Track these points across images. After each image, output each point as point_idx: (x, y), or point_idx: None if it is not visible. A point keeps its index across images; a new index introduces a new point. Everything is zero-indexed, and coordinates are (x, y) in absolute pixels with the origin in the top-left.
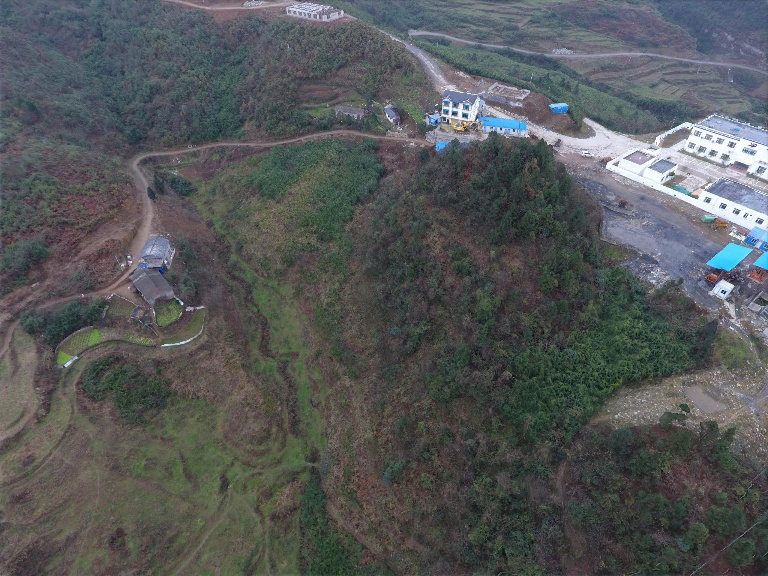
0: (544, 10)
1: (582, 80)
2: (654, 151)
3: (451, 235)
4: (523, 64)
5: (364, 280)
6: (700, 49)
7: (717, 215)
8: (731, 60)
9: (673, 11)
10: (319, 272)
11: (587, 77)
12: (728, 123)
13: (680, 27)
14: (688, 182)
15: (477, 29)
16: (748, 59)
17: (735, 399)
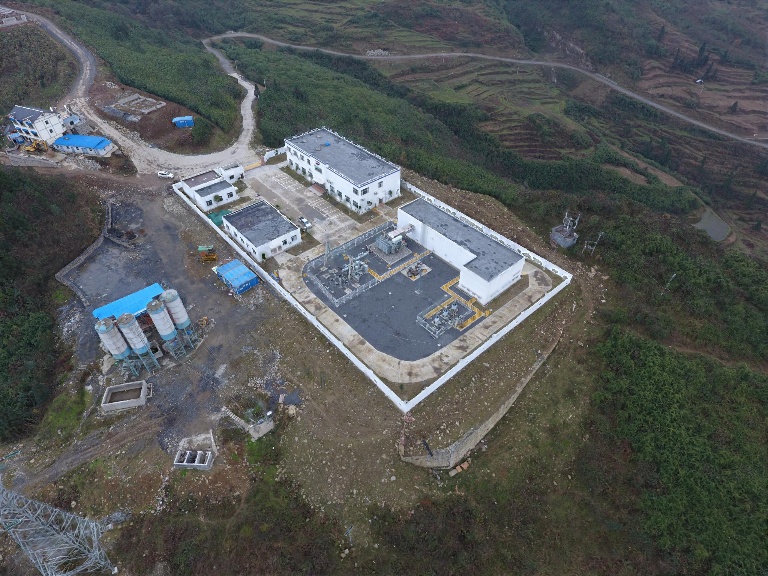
0: (367, 10)
1: (385, 83)
2: (228, 170)
3: None
4: (310, 67)
5: None
6: (533, 48)
7: (230, 244)
8: (557, 59)
9: (514, 9)
10: None
11: (389, 79)
12: (328, 137)
13: (505, 26)
14: (246, 205)
15: (293, 30)
16: (572, 58)
17: (6, 481)
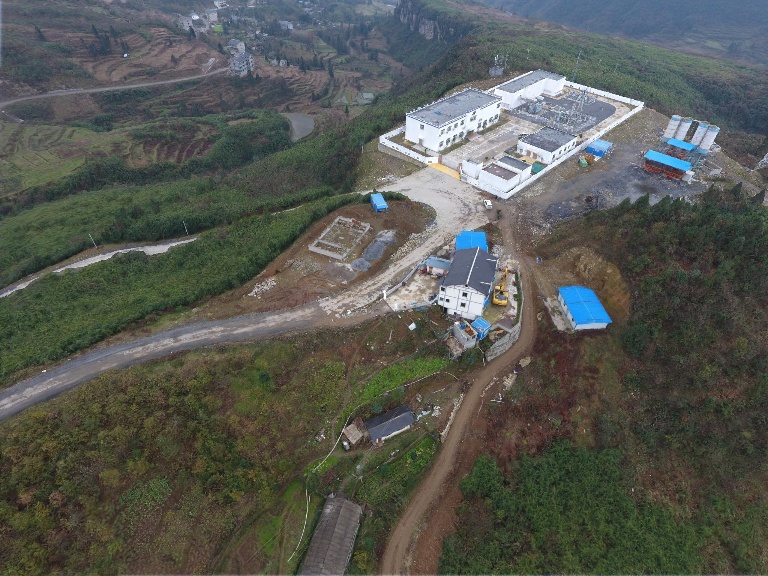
0: None
1: None
2: None
3: (767, 319)
4: None
5: (766, 472)
6: None
7: (565, 160)
8: None
9: None
10: (762, 568)
11: None
12: (423, 113)
13: None
14: None
15: None
16: None
17: None
